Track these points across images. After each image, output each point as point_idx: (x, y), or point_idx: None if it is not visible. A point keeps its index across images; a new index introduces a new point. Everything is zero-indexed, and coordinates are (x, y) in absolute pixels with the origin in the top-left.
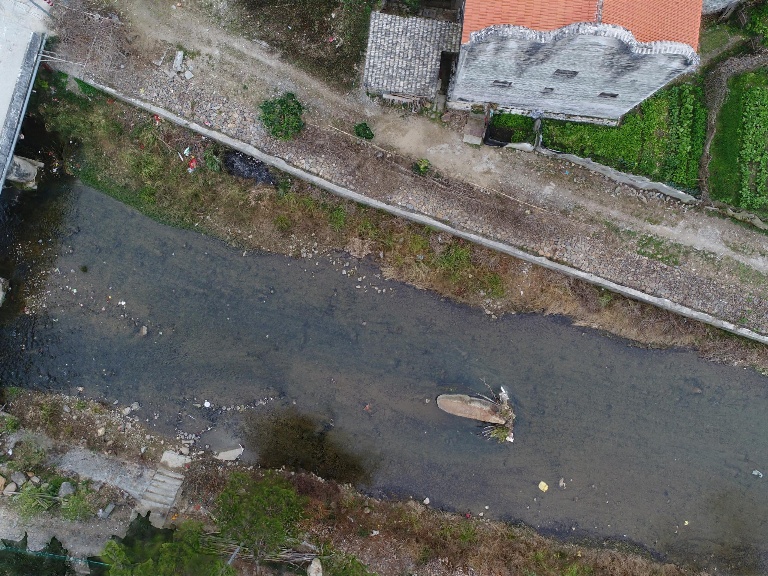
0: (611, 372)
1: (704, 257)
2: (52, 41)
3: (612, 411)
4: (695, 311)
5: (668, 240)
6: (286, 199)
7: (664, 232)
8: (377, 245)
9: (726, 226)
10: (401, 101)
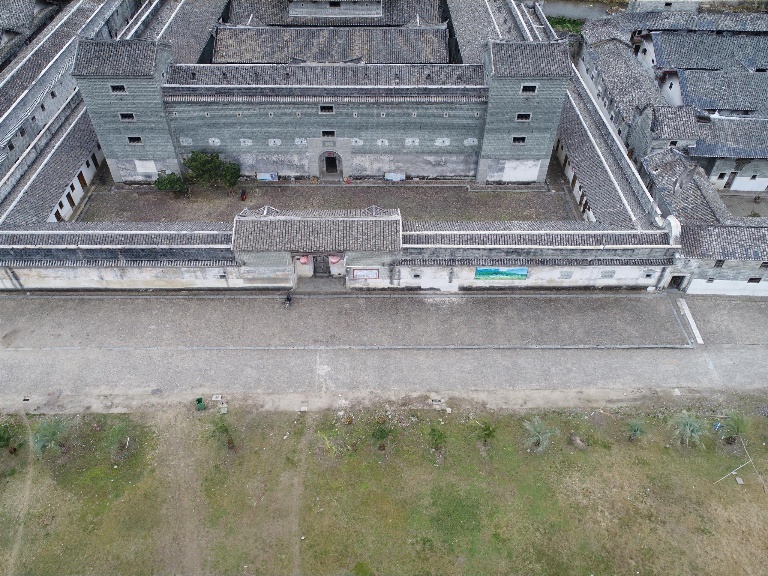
0: None
1: None
2: None
3: None
4: None
5: None
6: None
7: None
8: None
9: None
10: None
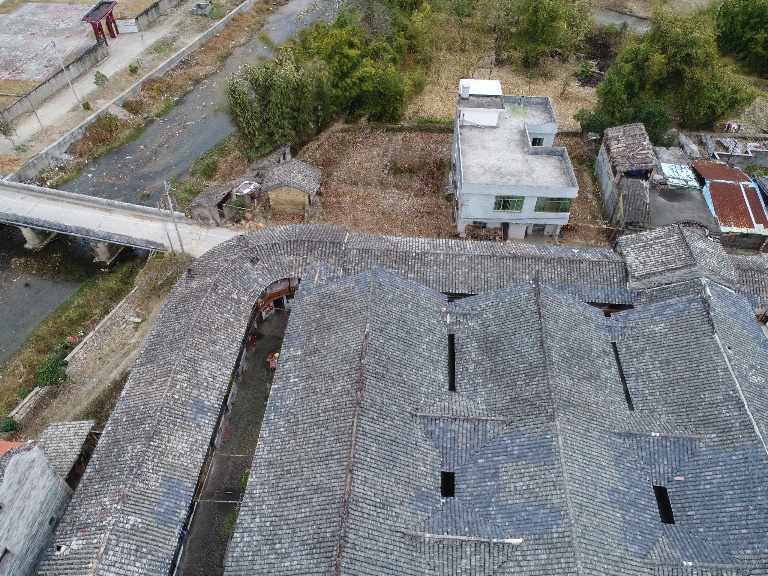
0: None
1: None
2: None
3: None
4: None
5: None
6: None
7: None
8: None
9: None
10: None
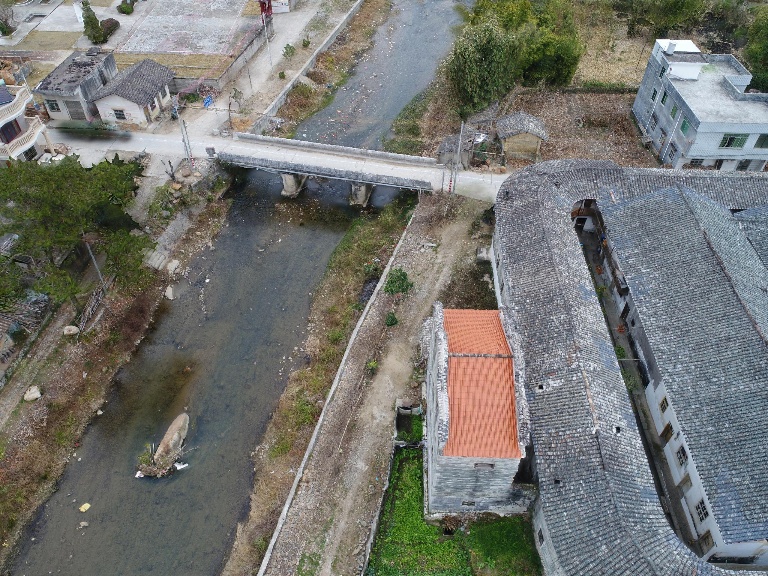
0: (186, 567)
1: None
2: (430, 194)
3: (145, 572)
4: None
5: None
6: None
7: None
8: None
9: None
10: None
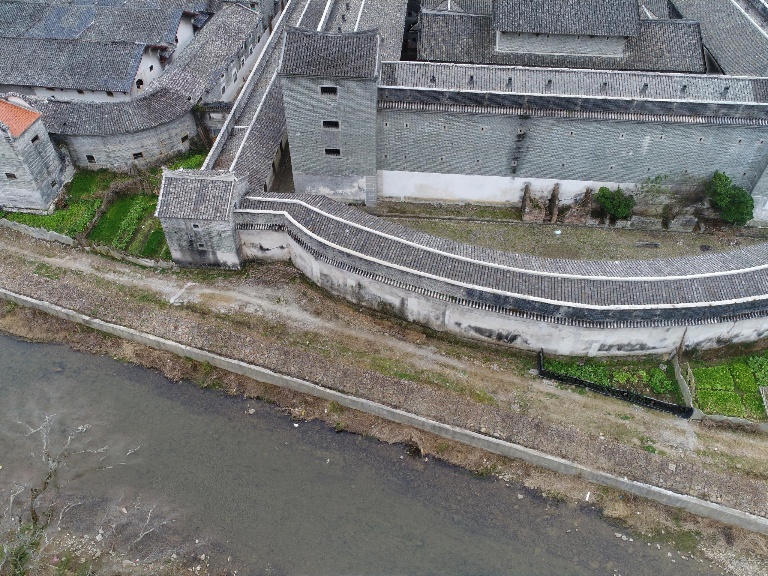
0: None
1: (75, 274)
2: None
3: None
4: (64, 309)
5: (55, 265)
6: None
7: (54, 261)
8: None
9: (96, 258)
10: None
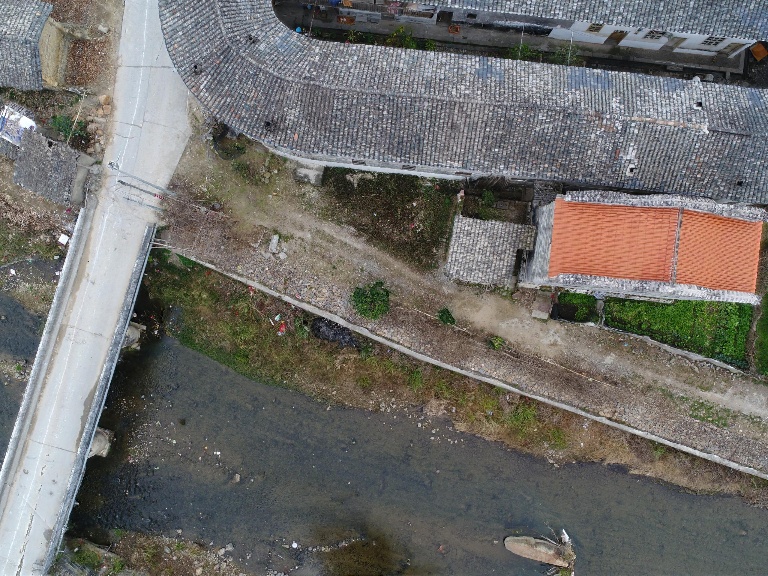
0: (663, 515)
1: (751, 421)
2: (162, 229)
3: (664, 551)
4: (742, 466)
5: (718, 405)
6: (368, 362)
7: (714, 398)
8: (450, 402)
9: None
10: (476, 283)
